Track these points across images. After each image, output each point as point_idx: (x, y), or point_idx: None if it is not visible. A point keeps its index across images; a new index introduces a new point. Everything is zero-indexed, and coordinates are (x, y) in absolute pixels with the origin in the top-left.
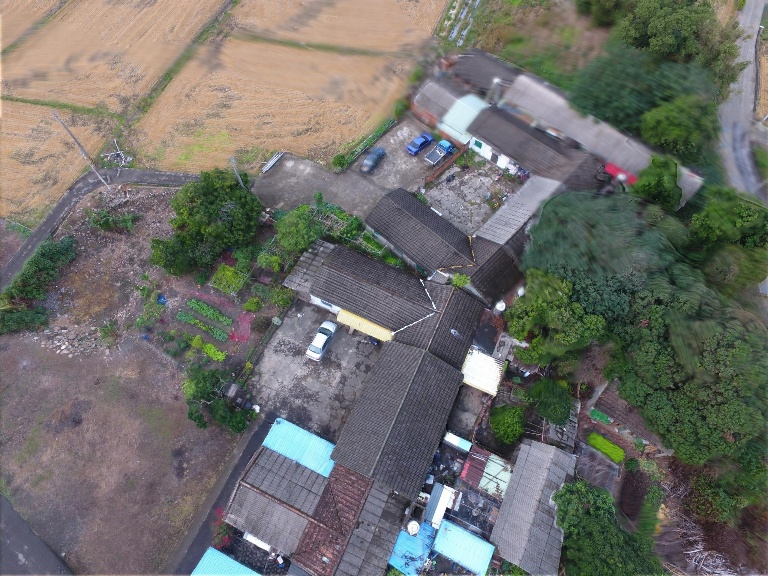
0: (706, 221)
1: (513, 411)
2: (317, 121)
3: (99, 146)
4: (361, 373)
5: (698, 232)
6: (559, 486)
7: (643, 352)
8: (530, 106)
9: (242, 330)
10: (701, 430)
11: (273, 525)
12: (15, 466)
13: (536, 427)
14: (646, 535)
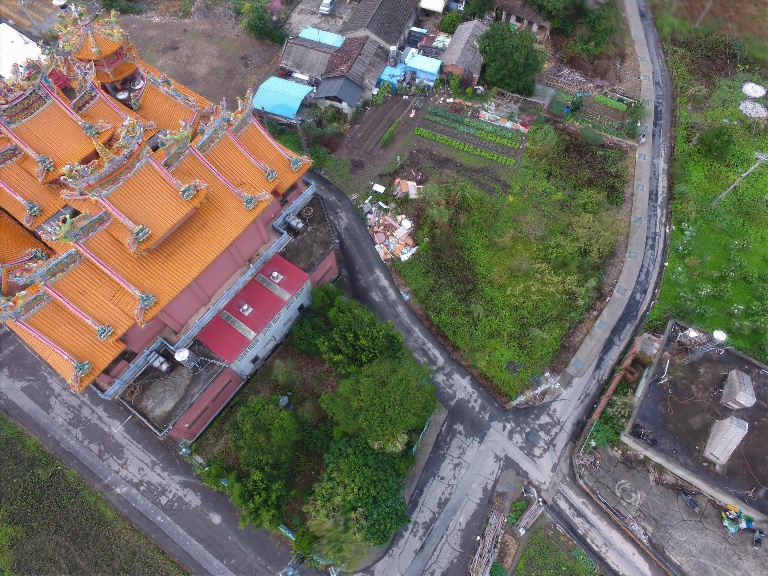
0: None
1: None
2: None
3: None
4: None
5: None
6: None
7: None
8: None
9: (275, 5)
10: None
11: (309, 62)
12: None
13: None
14: (525, 29)
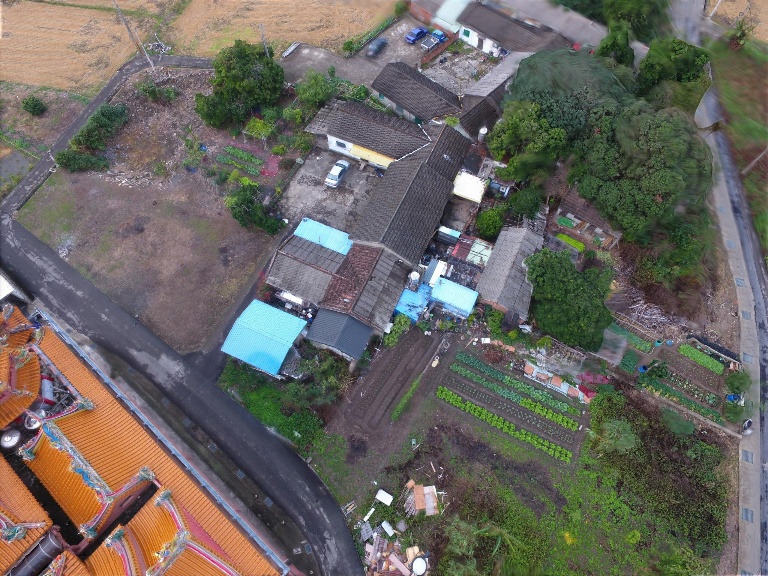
0: (649, 61)
1: (494, 209)
2: (328, 20)
3: (142, 38)
4: (370, 197)
5: (644, 73)
6: (530, 255)
7: (595, 152)
8: (510, 1)
9: (271, 168)
10: (637, 196)
11: (304, 282)
12: (93, 259)
13: (512, 222)
14: None
